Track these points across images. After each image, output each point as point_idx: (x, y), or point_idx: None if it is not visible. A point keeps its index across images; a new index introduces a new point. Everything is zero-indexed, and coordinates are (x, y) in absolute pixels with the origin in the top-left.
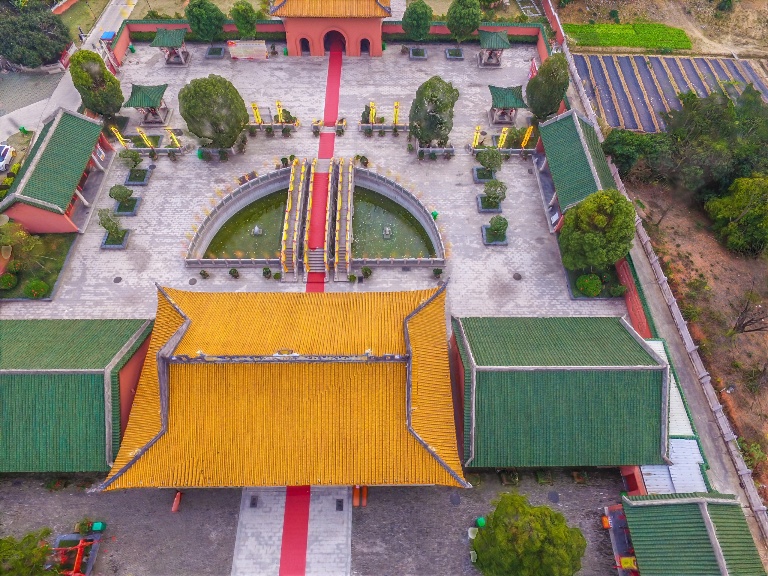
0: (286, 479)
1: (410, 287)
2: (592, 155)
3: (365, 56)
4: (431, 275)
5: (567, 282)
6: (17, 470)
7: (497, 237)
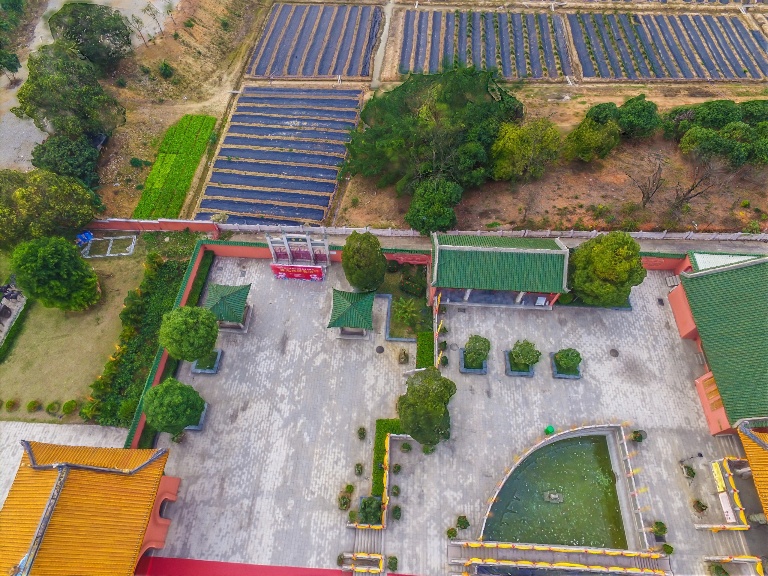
0: None
1: (655, 473)
2: None
3: (172, 510)
4: (632, 445)
5: (613, 309)
6: None
7: None
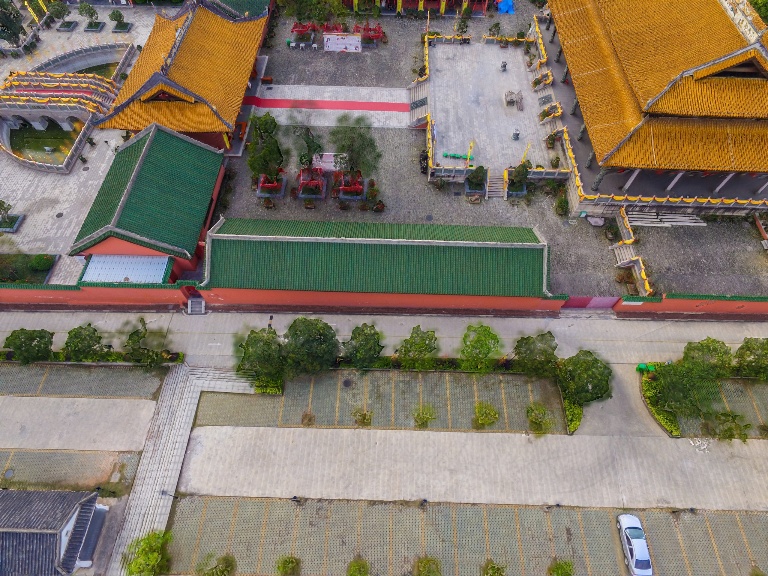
0: (248, 70)
1: None
2: None
3: None
4: None
5: (171, 7)
6: (209, 199)
7: (125, 25)
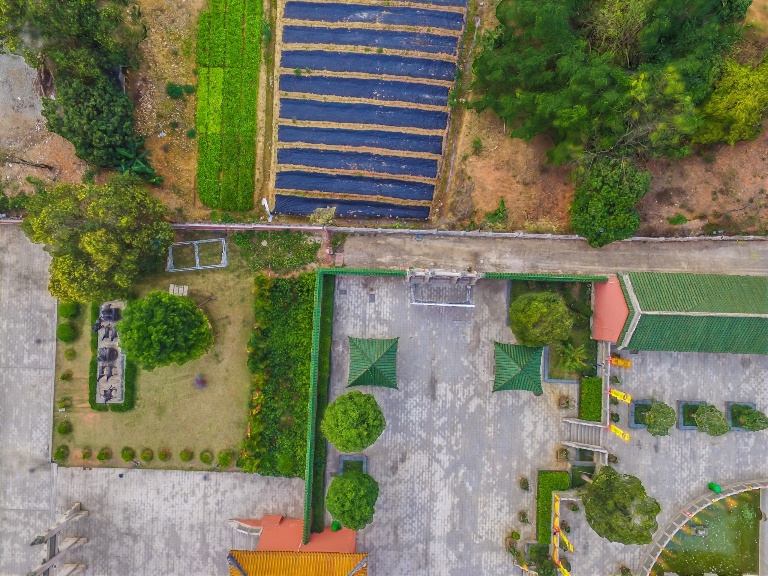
0: None
1: None
2: (705, 302)
3: None
4: None
5: None
6: None
7: None
